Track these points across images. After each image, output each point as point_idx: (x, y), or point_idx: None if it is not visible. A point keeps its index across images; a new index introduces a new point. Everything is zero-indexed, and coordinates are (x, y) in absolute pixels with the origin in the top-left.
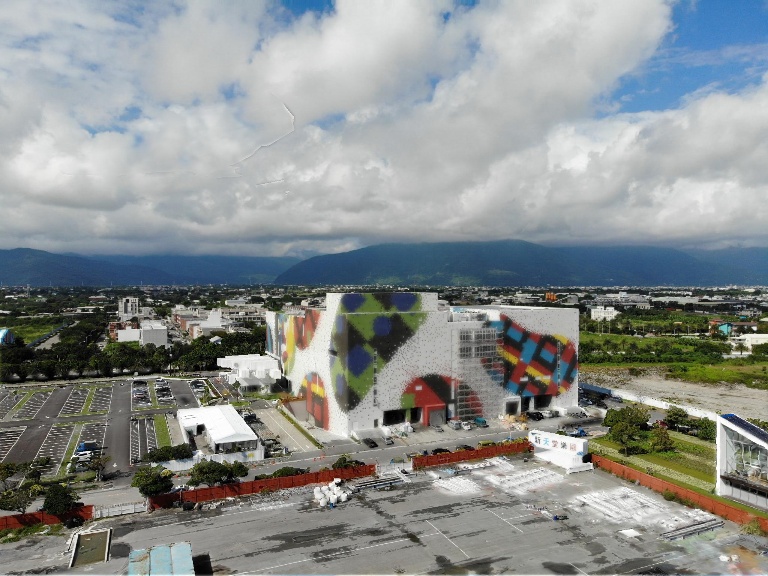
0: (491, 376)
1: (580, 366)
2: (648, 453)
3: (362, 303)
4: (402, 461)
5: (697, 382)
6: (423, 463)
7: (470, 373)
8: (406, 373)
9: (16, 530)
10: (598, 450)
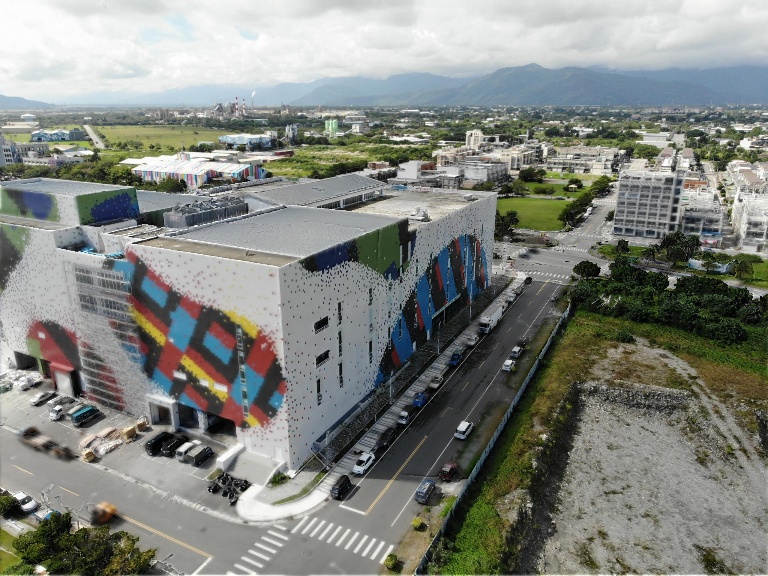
0: (123, 351)
1: (750, 371)
2: None
3: None
4: None
5: None
6: None
7: (98, 336)
8: (25, 310)
9: None
10: None
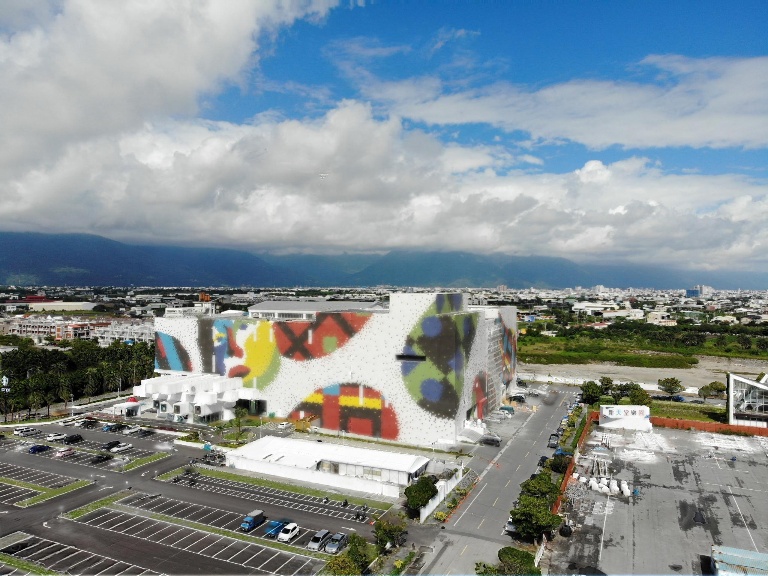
0: None
1: None
2: None
3: (444, 304)
4: None
5: None
6: None
7: (491, 367)
8: (473, 372)
9: None
10: None
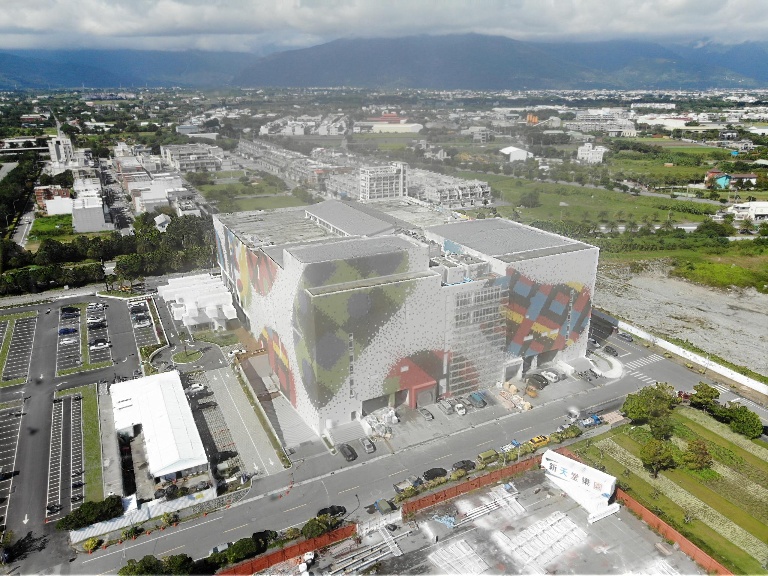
0: (491, 342)
1: None
2: (678, 467)
3: (331, 273)
4: (389, 510)
5: (704, 285)
6: (414, 507)
7: (466, 342)
8: (389, 355)
9: None
10: (619, 461)
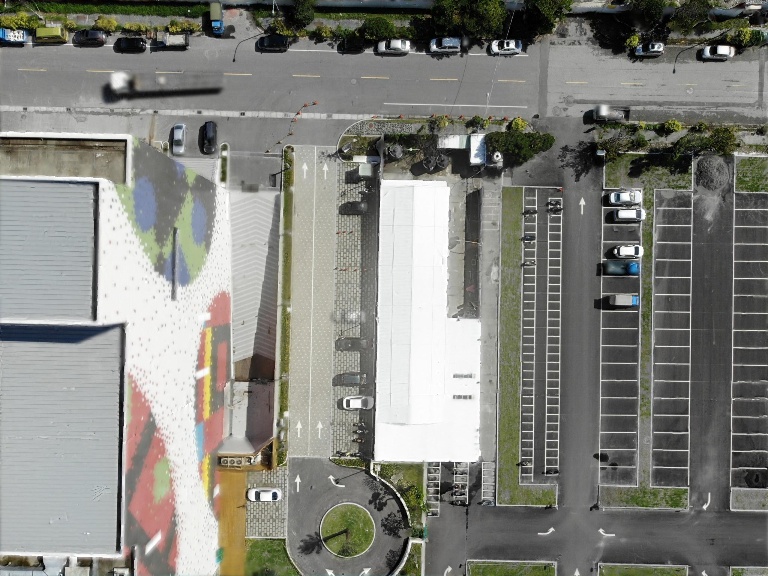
0: None
1: None
2: None
3: None
4: (215, 2)
5: None
6: (186, 0)
7: None
8: None
9: (676, 7)
10: None
